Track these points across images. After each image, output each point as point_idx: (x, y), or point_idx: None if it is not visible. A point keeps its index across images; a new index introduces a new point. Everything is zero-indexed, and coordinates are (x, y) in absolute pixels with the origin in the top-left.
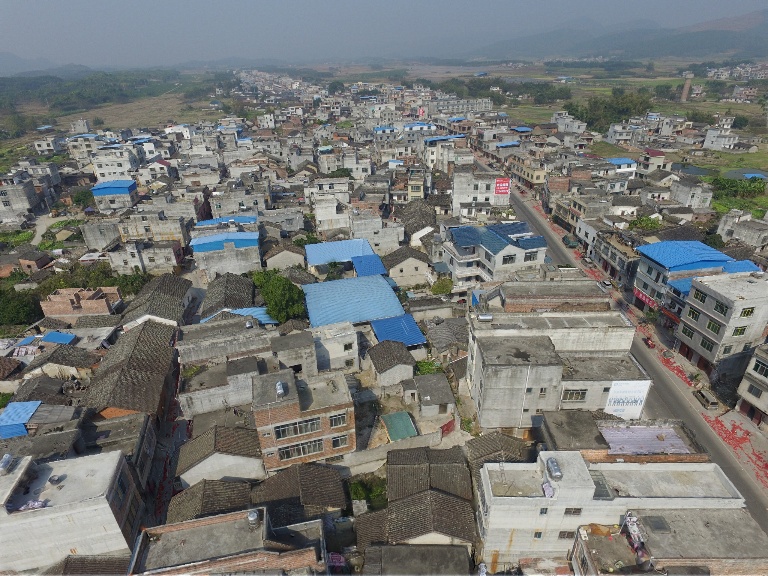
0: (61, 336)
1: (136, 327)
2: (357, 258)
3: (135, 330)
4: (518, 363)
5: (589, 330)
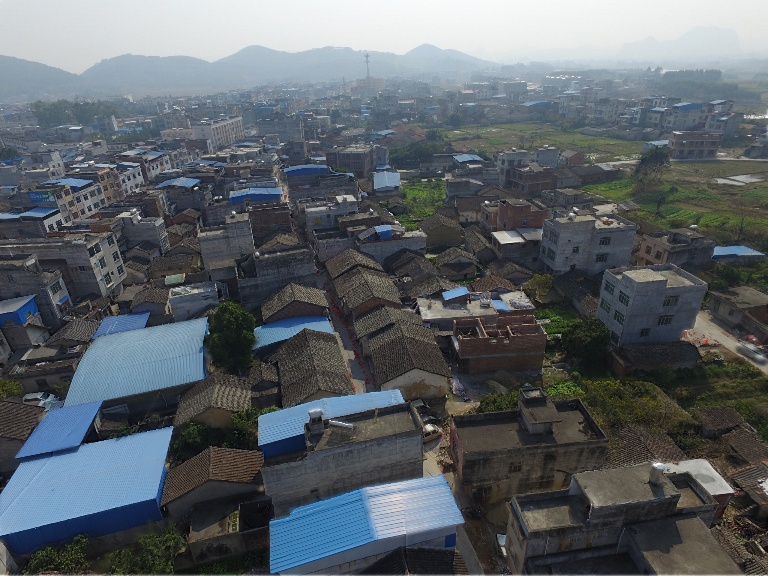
0: (454, 294)
1: (384, 298)
2: (69, 442)
3: (382, 295)
4: (94, 233)
5: (23, 241)
